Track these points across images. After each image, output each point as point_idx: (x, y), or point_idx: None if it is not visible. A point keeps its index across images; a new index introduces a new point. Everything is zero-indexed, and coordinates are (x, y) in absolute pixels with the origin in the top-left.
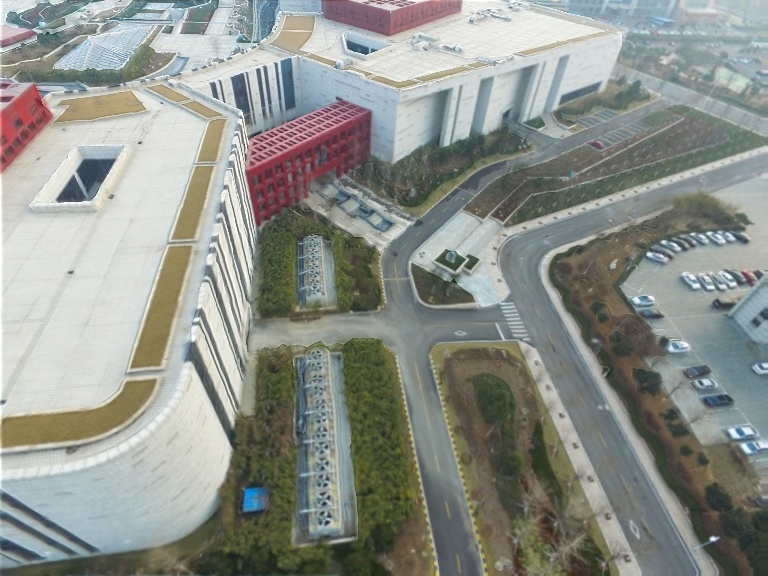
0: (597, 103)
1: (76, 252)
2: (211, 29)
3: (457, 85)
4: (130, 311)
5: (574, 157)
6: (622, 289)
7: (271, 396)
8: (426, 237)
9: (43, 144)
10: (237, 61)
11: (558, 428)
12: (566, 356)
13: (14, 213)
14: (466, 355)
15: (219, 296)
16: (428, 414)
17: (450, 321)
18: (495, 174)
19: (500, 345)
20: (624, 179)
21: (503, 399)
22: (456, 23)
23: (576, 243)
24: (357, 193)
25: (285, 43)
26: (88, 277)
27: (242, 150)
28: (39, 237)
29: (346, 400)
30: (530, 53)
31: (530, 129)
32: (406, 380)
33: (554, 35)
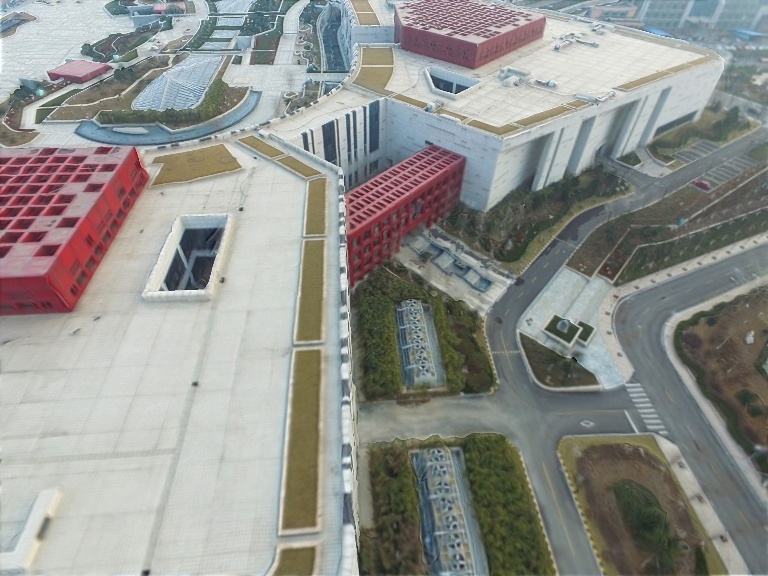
0: (693, 134)
1: (196, 356)
2: (279, 58)
3: (559, 128)
4: (267, 441)
5: (679, 200)
6: (766, 370)
7: (394, 508)
8: (530, 299)
9: (144, 212)
10: (323, 104)
11: (722, 556)
12: (713, 456)
13: (126, 303)
14: (599, 453)
15: None
16: (568, 532)
17: (573, 408)
18: (594, 221)
19: (634, 440)
20: (740, 227)
21: (660, 522)
22: (540, 51)
23: (699, 307)
24: (450, 246)
25: (368, 81)
26: (214, 391)
27: None
28: (155, 335)
29: (475, 513)
30: (631, 87)
31: (625, 166)
32: (536, 485)
33: (650, 63)
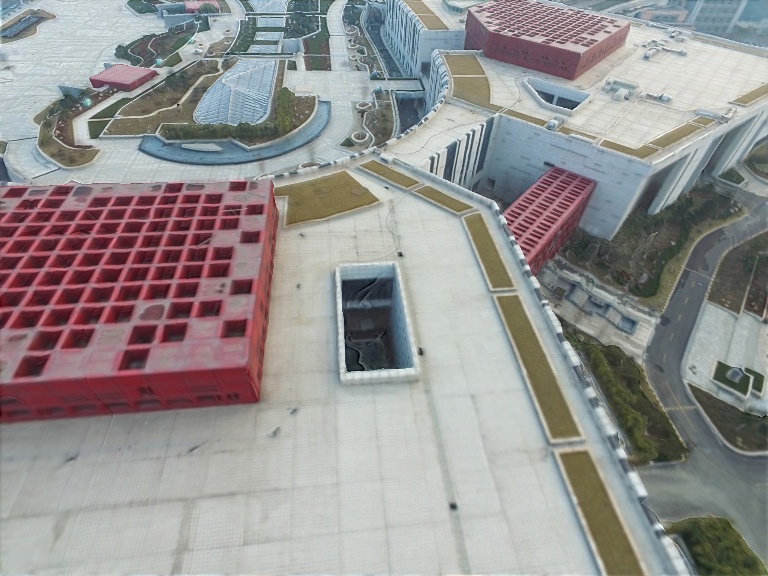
0: None
1: (437, 462)
2: (336, 63)
3: (694, 149)
4: None
5: None
6: None
7: None
8: (684, 342)
9: (292, 261)
10: (432, 121)
11: None
12: None
13: (320, 387)
14: None
15: None
16: None
17: None
18: (719, 248)
19: None
20: None
21: None
22: (630, 60)
23: None
24: (579, 279)
25: (468, 94)
26: (482, 516)
27: None
28: (374, 433)
29: None
30: (748, 102)
31: (728, 185)
32: None
33: (750, 74)
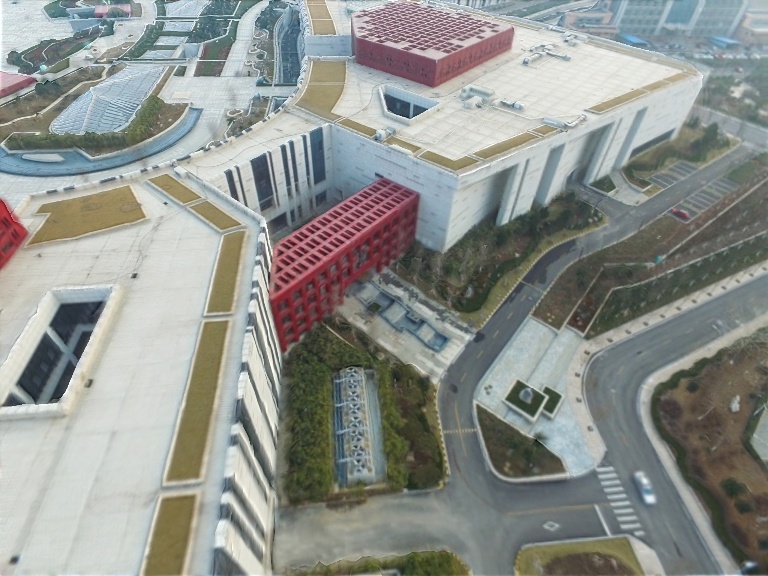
0: (671, 154)
1: (28, 509)
2: (228, 69)
3: (523, 159)
4: None
5: (657, 233)
6: (754, 447)
7: None
8: (491, 360)
9: (9, 284)
10: (258, 132)
11: None
12: (697, 564)
13: None
14: (564, 568)
15: (234, 570)
16: None
17: (535, 504)
18: (565, 260)
19: (606, 546)
20: (722, 264)
21: None
22: (508, 65)
23: (678, 365)
24: (402, 294)
25: (313, 102)
26: (39, 570)
27: (265, 276)
28: None
29: None
30: (604, 109)
31: (598, 193)
32: None
33: (625, 80)
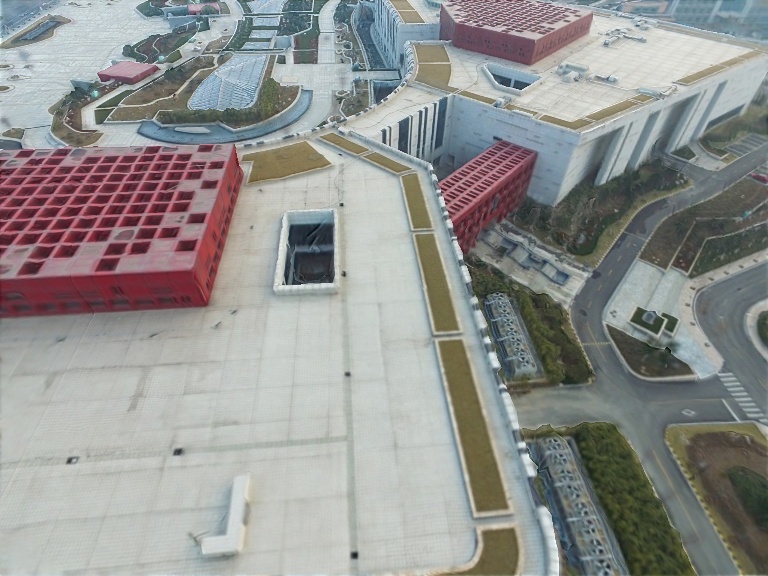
0: (741, 127)
1: (341, 347)
2: (322, 57)
3: (628, 122)
4: (434, 428)
5: (740, 193)
6: None
7: None
8: (610, 292)
9: (249, 209)
10: (391, 101)
11: None
12: None
13: (258, 296)
14: (706, 441)
15: None
16: (691, 518)
17: (672, 397)
18: (659, 215)
19: (737, 428)
20: None
21: None
22: (590, 47)
23: None
24: (522, 240)
25: (430, 78)
26: (369, 380)
27: None
28: (295, 327)
29: (598, 500)
30: (691, 81)
31: (680, 160)
32: (651, 473)
33: (702, 57)
